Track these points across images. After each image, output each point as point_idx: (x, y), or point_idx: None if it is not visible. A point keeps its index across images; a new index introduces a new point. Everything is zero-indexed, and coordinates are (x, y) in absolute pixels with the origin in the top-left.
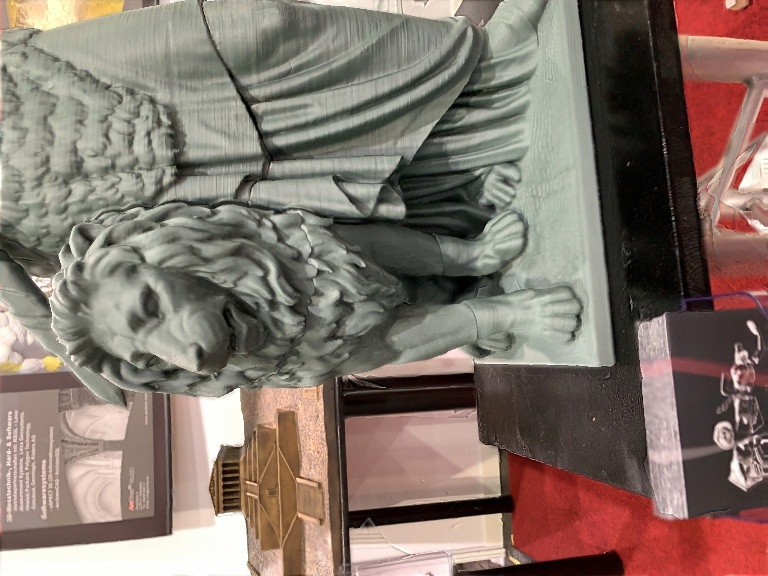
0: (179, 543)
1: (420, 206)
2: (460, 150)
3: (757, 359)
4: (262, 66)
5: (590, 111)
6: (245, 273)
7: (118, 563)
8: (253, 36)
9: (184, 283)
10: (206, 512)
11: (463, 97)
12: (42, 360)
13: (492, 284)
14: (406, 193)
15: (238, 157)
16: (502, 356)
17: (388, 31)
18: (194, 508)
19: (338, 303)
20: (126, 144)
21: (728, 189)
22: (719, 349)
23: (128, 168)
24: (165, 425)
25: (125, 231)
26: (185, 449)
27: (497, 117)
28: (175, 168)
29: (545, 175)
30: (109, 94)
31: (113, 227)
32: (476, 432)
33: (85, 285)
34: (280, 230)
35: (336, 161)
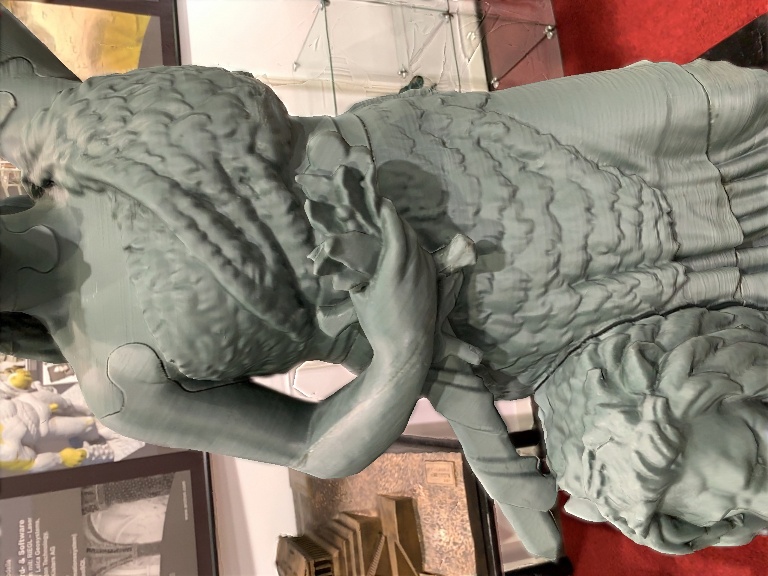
0: None
1: None
2: None
3: None
4: (735, 142)
5: None
6: None
7: None
8: (749, 108)
9: None
10: None
11: None
12: (59, 454)
13: None
14: None
15: (722, 248)
16: None
17: None
18: None
19: None
20: (637, 237)
21: None
22: None
23: (633, 266)
24: (208, 518)
25: (704, 352)
26: (226, 543)
27: None
28: (683, 265)
29: None
30: (608, 175)
31: (694, 348)
32: None
33: (681, 428)
34: None
35: None
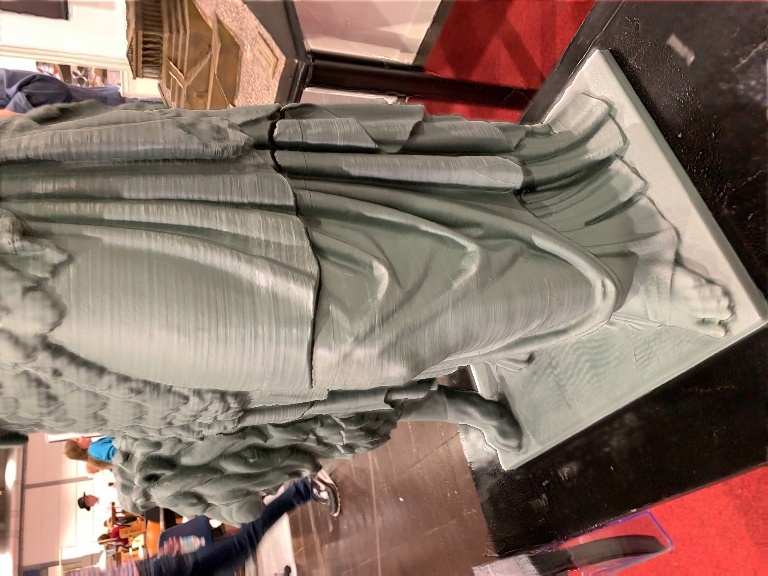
0: (74, 17)
1: None
2: None
3: (569, 571)
4: None
5: (635, 400)
6: None
7: (5, 24)
8: None
9: None
10: None
11: None
12: None
13: None
14: None
15: None
16: None
17: (516, 338)
18: None
19: None
20: None
21: None
22: None
23: None
24: None
25: None
26: None
27: None
28: (237, 423)
29: (569, 377)
30: (174, 400)
31: (180, 490)
32: None
33: None
34: (322, 436)
35: None
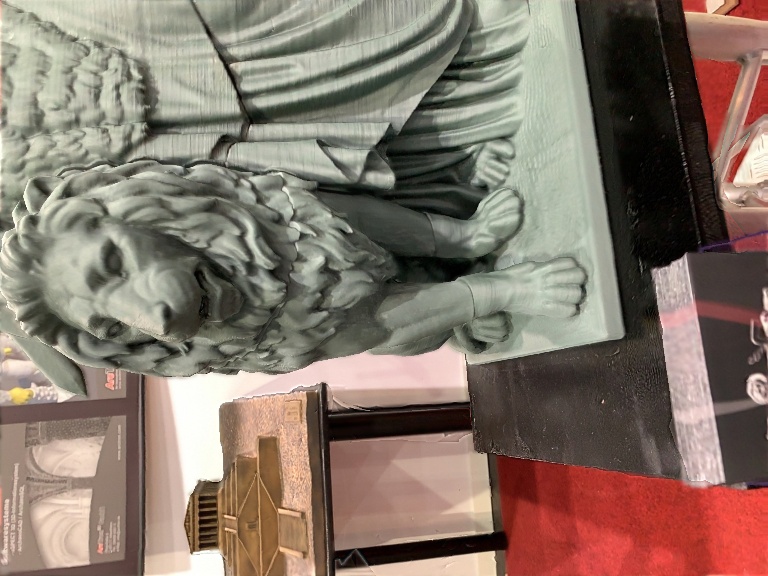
0: None
1: (409, 187)
2: (451, 125)
3: None
4: (242, 23)
5: (587, 74)
6: (220, 232)
7: None
8: None
9: (151, 239)
10: (181, 555)
11: (453, 69)
12: (9, 392)
13: (486, 269)
14: (394, 172)
15: (215, 117)
16: (498, 349)
17: None
18: (168, 551)
19: (323, 270)
20: (92, 97)
21: (723, 181)
22: (746, 294)
23: (94, 124)
24: (139, 460)
25: (87, 182)
26: (160, 486)
27: (488, 90)
28: (145, 124)
29: (541, 145)
30: (75, 46)
31: (73, 177)
32: (466, 465)
33: (39, 239)
34: (259, 192)
35: (320, 125)
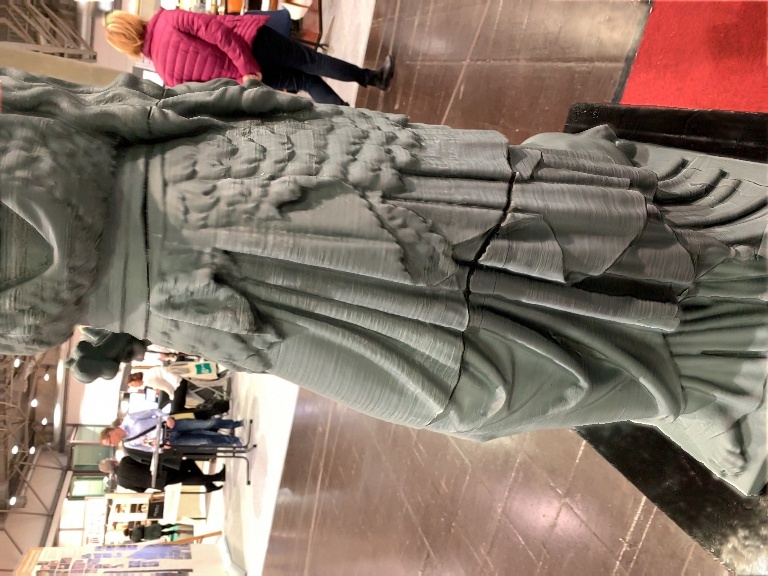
0: None
1: None
2: None
3: None
4: None
5: None
6: None
7: None
8: None
9: None
10: None
11: None
12: None
13: None
14: None
15: None
16: None
17: None
18: None
19: None
20: None
21: None
22: None
23: None
24: None
25: None
26: None
27: None
28: None
29: None
30: None
31: None
32: None
33: None
34: None
35: None
